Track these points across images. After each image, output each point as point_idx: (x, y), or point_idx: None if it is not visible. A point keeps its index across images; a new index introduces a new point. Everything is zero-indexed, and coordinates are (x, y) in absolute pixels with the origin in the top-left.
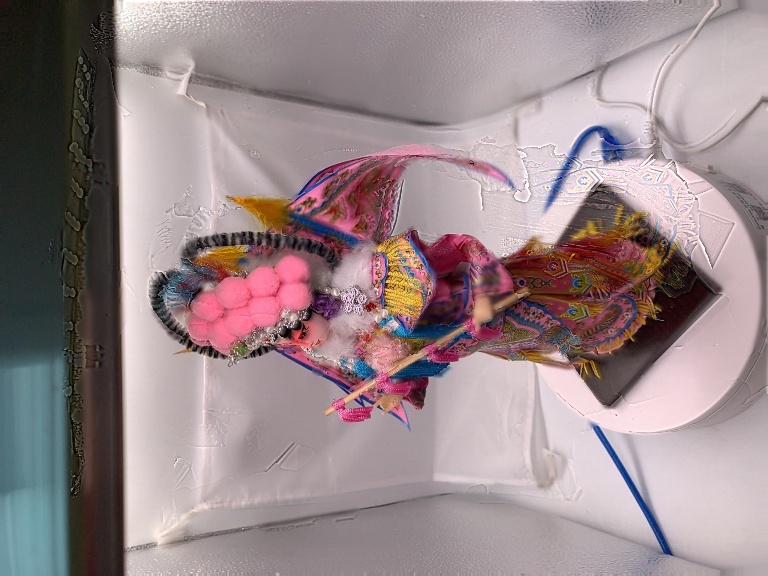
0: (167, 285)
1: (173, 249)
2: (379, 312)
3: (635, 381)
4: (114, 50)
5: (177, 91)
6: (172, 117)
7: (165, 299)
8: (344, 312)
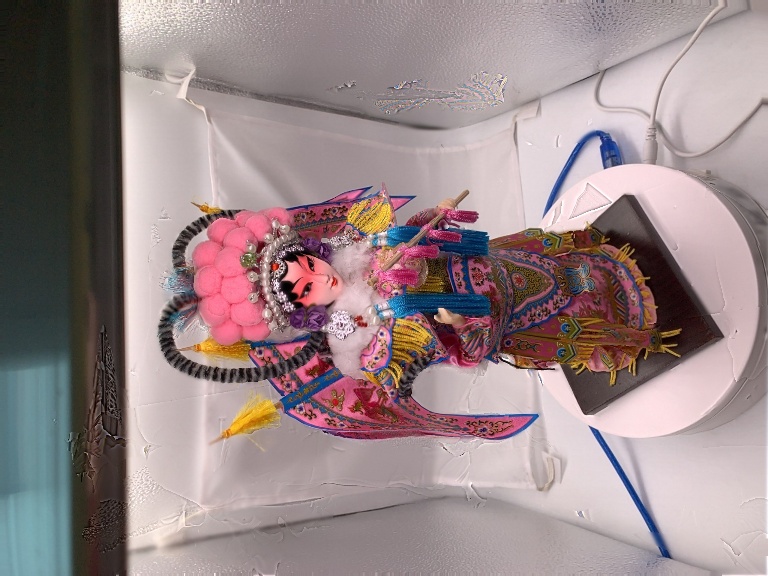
0: (176, 326)
1: (165, 254)
2: (366, 239)
3: (696, 294)
4: (107, 535)
5: (176, 531)
6: (178, 552)
7: (179, 347)
8: (338, 250)
